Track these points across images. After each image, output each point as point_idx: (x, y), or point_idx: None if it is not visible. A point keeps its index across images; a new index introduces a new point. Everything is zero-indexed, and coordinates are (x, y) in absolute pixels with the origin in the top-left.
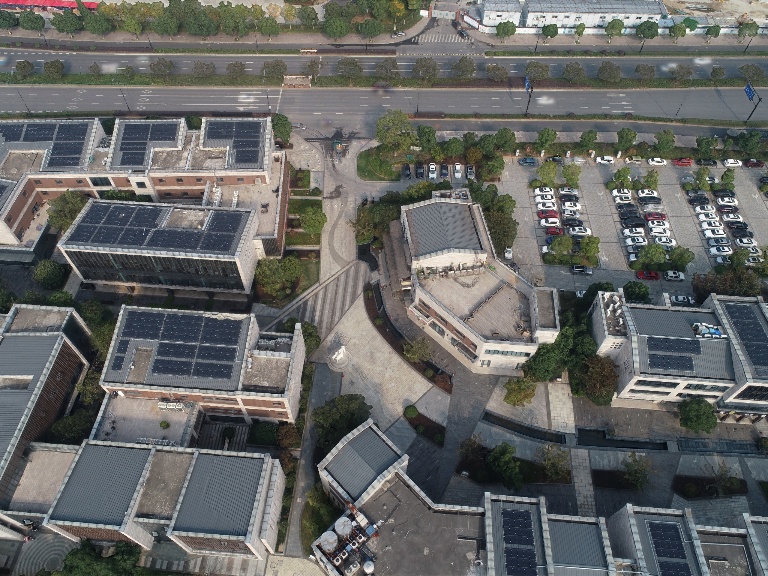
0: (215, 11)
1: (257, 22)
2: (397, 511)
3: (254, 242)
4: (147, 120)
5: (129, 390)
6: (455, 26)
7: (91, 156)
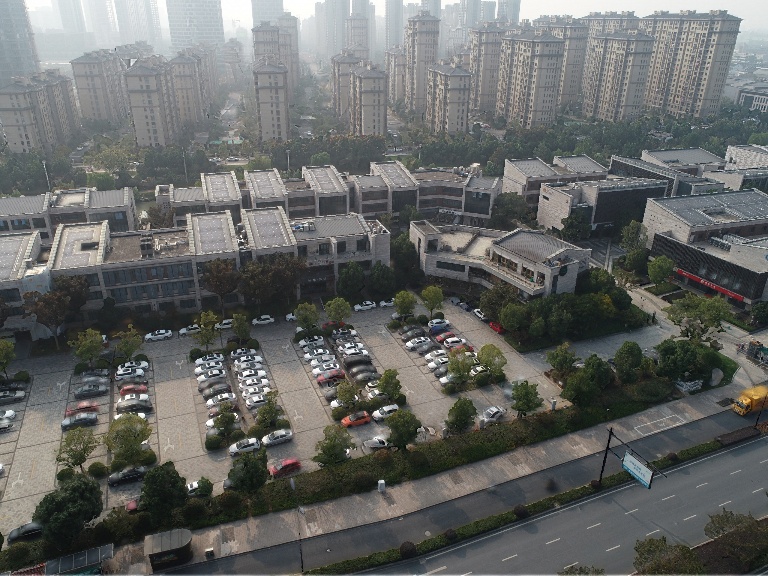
0: None
1: None
2: None
3: None
4: None
5: None
6: None
7: None
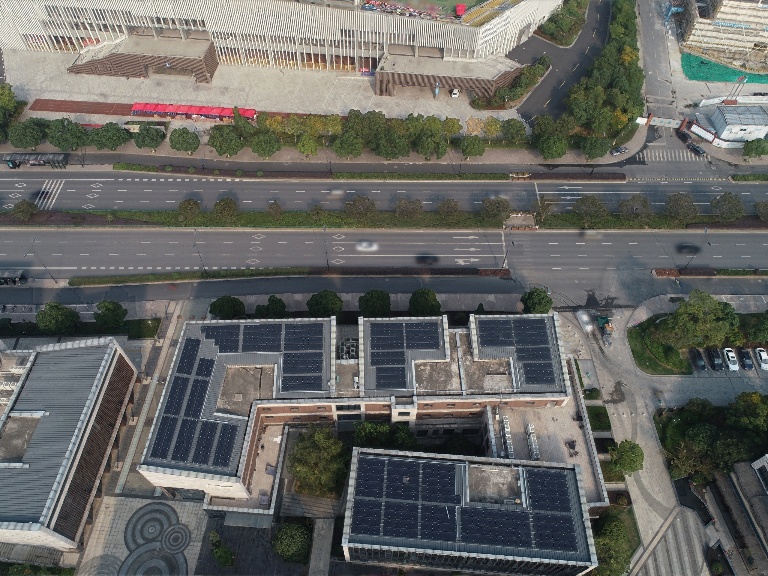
0: (403, 126)
1: (450, 136)
2: None
3: None
4: (398, 318)
5: None
6: (682, 138)
7: (337, 376)
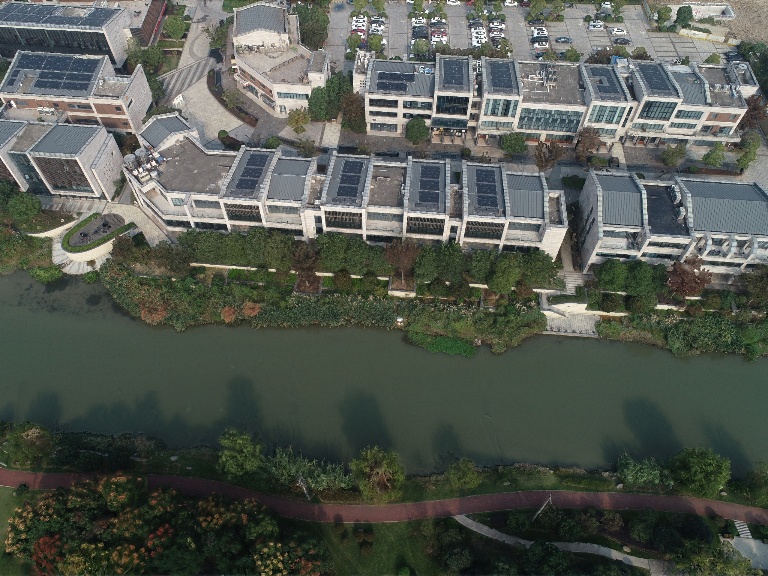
0: None
1: None
2: (182, 154)
3: (125, 31)
4: None
5: (18, 99)
6: None
7: None
